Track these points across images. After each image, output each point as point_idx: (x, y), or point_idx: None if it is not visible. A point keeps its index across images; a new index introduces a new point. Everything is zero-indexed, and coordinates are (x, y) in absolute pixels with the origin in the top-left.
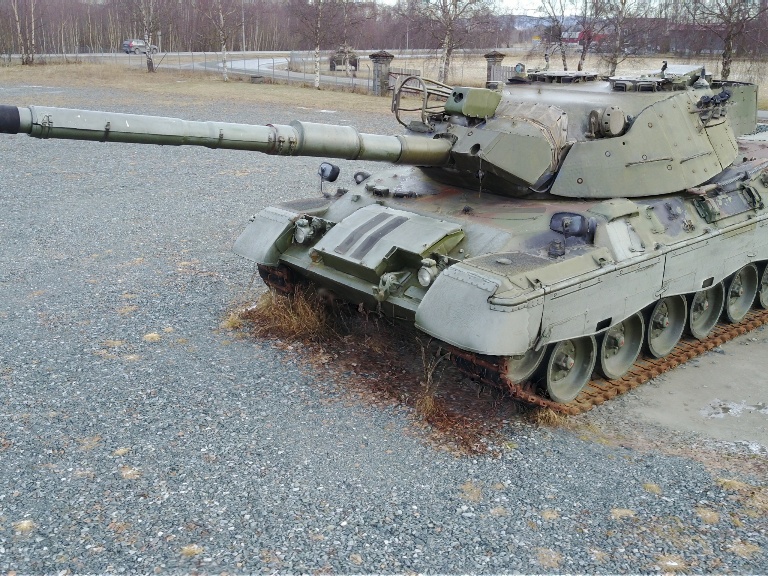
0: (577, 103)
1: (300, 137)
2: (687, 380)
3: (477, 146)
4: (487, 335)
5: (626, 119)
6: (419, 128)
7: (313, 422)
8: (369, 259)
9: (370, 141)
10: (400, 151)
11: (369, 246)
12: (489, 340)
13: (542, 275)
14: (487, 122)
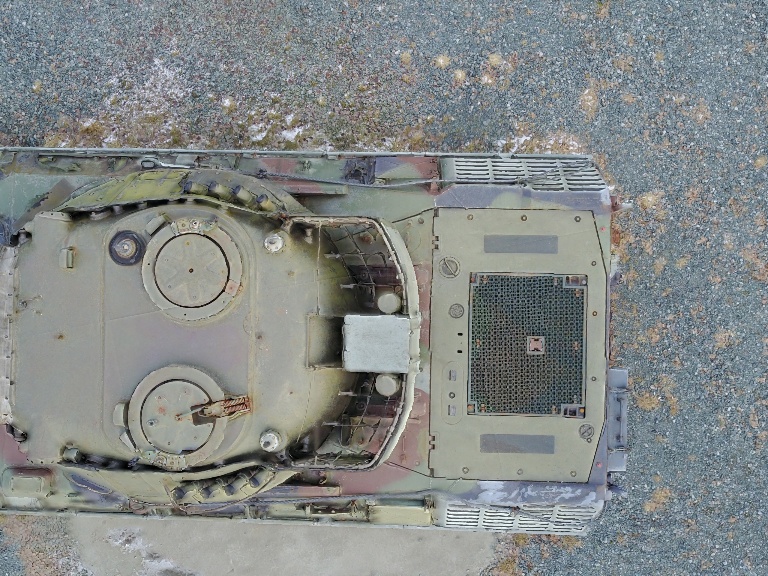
0: (30, 416)
1: None
2: None
3: None
4: None
5: (66, 459)
6: None
7: None
8: None
9: None
10: None
11: None
12: None
13: None
14: None
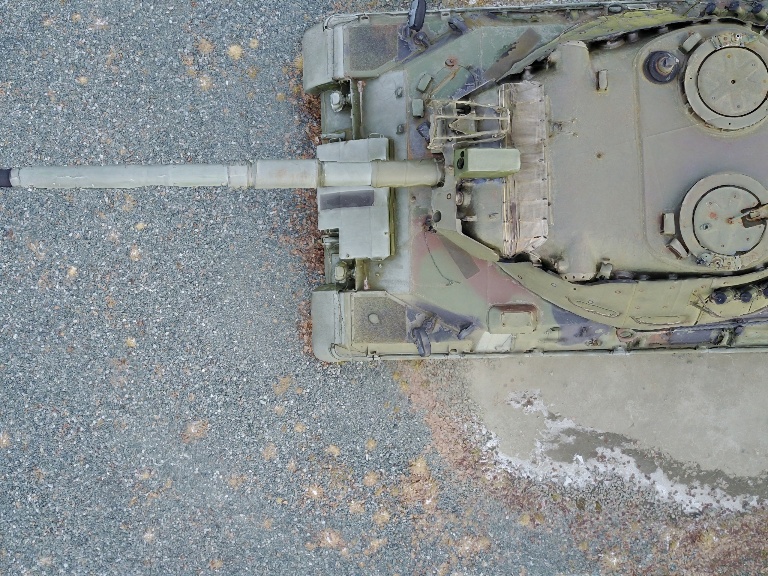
0: (570, 234)
1: (253, 185)
2: (551, 358)
3: (440, 216)
4: (321, 355)
5: (598, 276)
6: (443, 126)
7: (259, 260)
8: (323, 218)
9: (333, 182)
10: (370, 185)
11: (332, 204)
12: (321, 356)
13: (385, 347)
14: (488, 181)
